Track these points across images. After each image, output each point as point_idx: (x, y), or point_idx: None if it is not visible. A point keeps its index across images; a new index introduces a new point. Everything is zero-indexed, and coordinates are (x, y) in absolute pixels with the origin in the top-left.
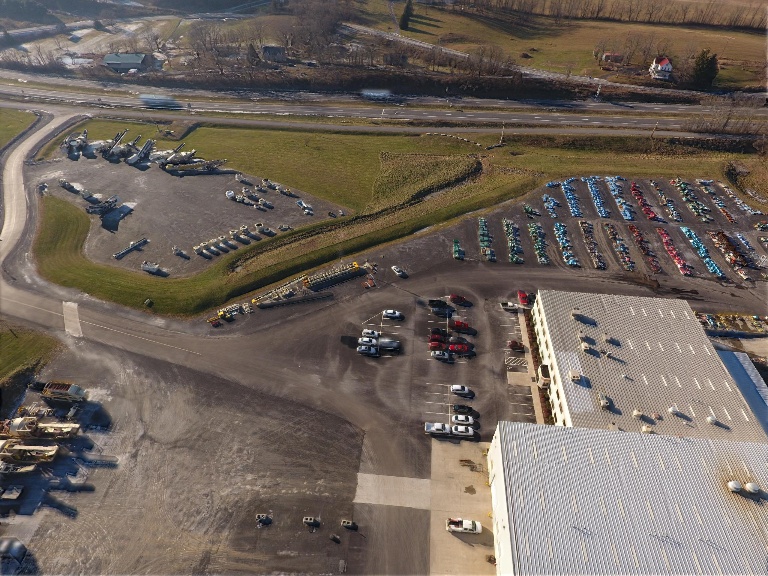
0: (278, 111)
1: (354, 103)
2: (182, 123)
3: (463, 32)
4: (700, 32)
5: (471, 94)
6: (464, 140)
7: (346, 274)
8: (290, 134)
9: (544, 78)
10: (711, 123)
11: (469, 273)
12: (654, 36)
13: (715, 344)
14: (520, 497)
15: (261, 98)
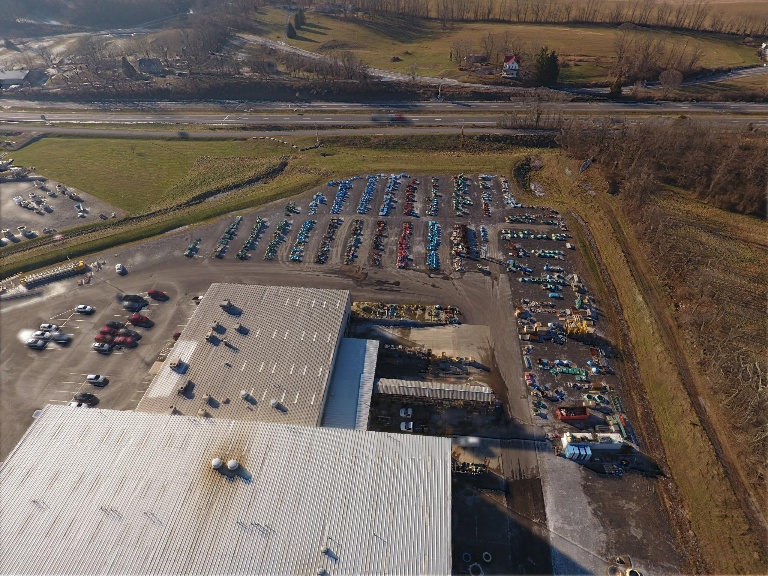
0: (127, 120)
1: (205, 110)
2: (28, 134)
3: (346, 38)
4: (578, 30)
5: (321, 98)
6: (284, 143)
7: (69, 272)
8: (125, 142)
9: (394, 80)
10: (524, 119)
11: (188, 269)
12: (509, 35)
13: (383, 333)
14: (7, 474)
15: (120, 108)
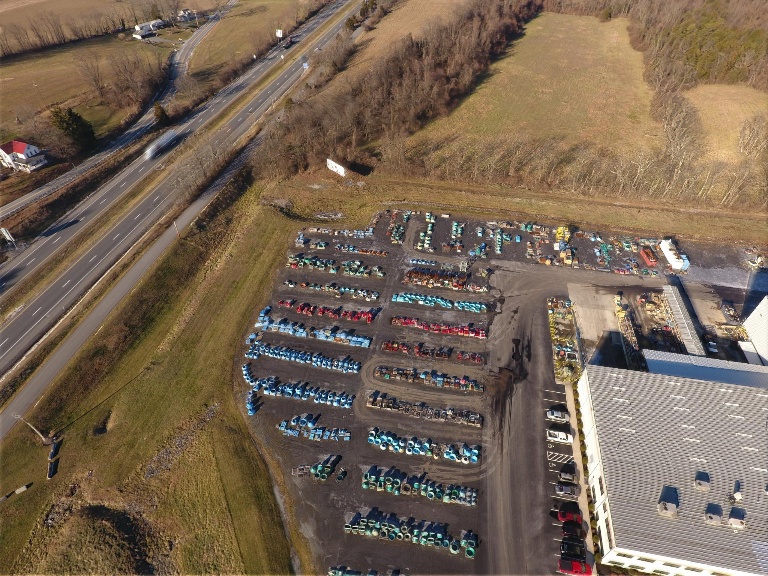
0: None
1: None
2: None
3: None
4: None
5: None
6: None
7: None
8: None
9: None
10: (193, 181)
11: None
12: None
13: (596, 361)
14: None
15: None
